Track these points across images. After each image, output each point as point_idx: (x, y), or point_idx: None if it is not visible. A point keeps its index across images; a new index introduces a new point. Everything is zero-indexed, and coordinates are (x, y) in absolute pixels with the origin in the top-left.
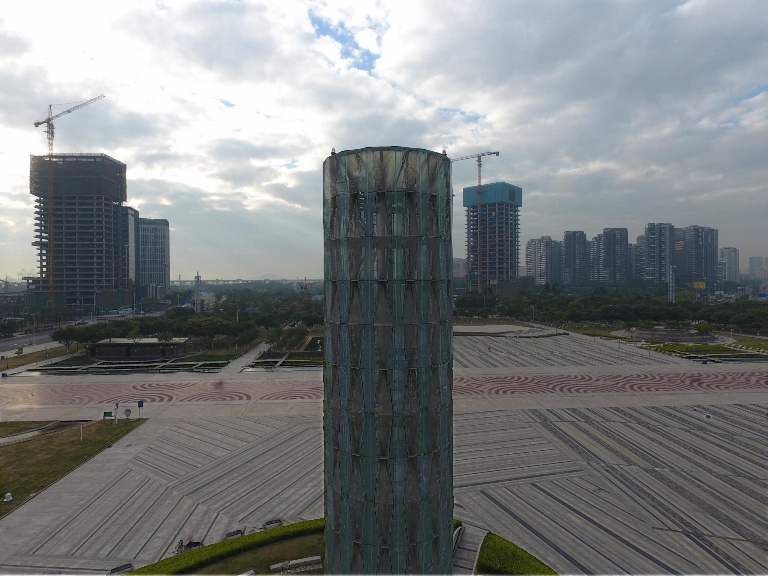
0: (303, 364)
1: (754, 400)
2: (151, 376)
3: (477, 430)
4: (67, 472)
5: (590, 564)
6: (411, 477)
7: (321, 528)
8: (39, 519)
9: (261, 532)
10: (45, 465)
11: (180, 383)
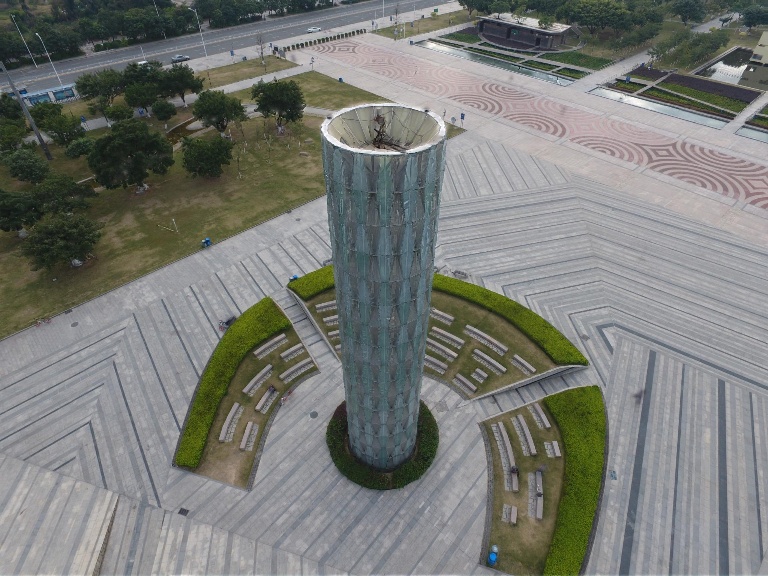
0: (669, 100)
1: None
2: (506, 74)
3: (762, 289)
4: None
5: (651, 469)
6: (358, 350)
7: (471, 300)
8: None
9: (443, 278)
10: None
11: (522, 92)
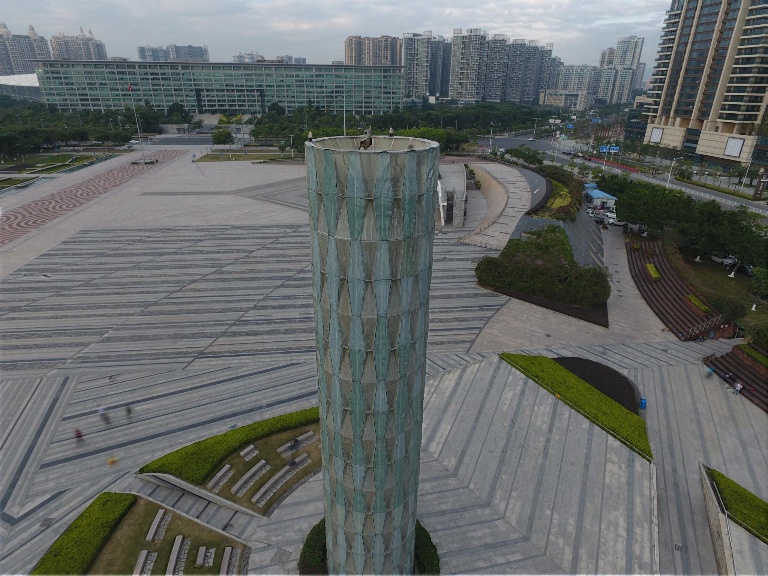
0: None
1: (44, 246)
2: None
3: None
4: None
5: (209, 415)
6: None
7: None
8: None
9: None
10: None
11: None
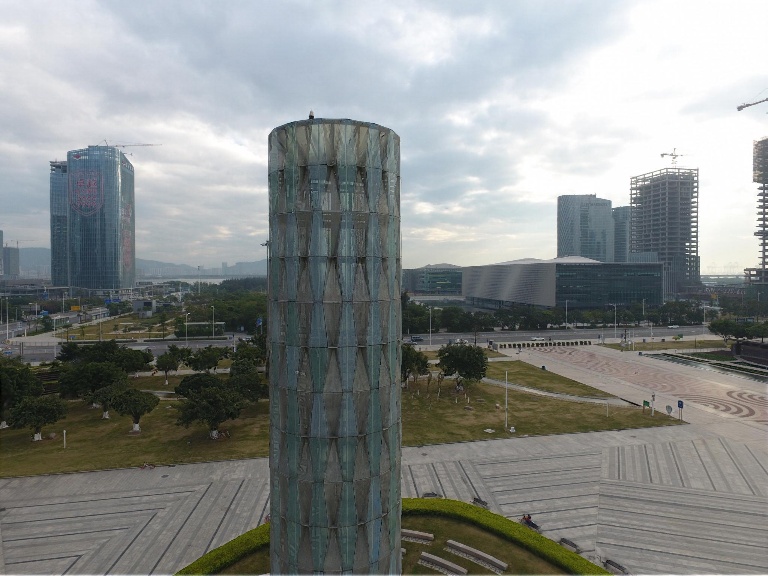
0: None
1: None
2: None
3: None
4: (563, 433)
5: None
6: None
7: None
8: (506, 450)
9: (576, 556)
10: (561, 422)
11: None
